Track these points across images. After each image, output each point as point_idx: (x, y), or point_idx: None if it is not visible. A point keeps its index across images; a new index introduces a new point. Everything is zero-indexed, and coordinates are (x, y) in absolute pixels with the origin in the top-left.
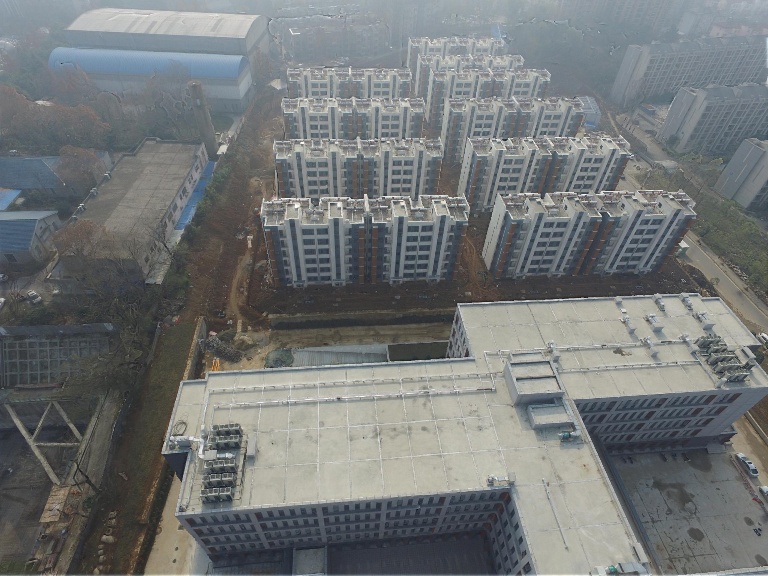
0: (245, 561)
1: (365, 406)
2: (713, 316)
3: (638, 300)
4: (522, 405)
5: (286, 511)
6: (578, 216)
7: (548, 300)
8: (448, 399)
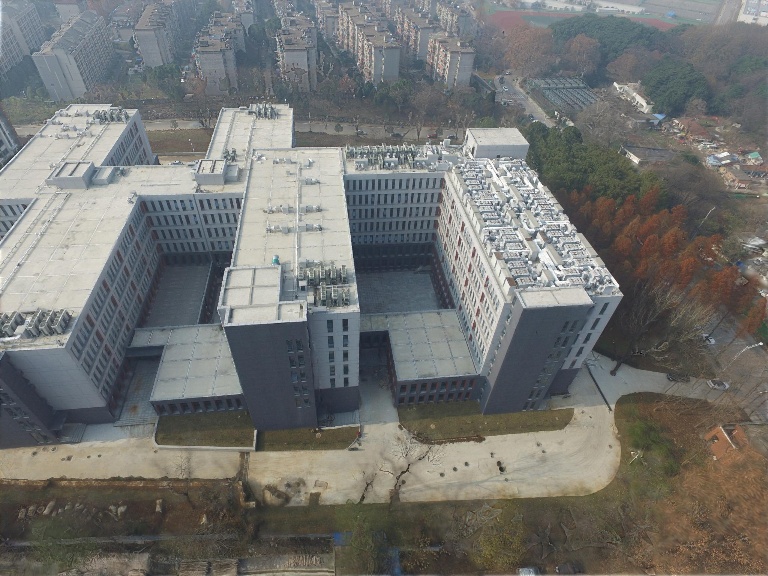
0: (123, 395)
1: (37, 252)
2: None
3: (46, 129)
4: (89, 185)
5: (97, 299)
6: None
7: (11, 160)
8: (61, 213)
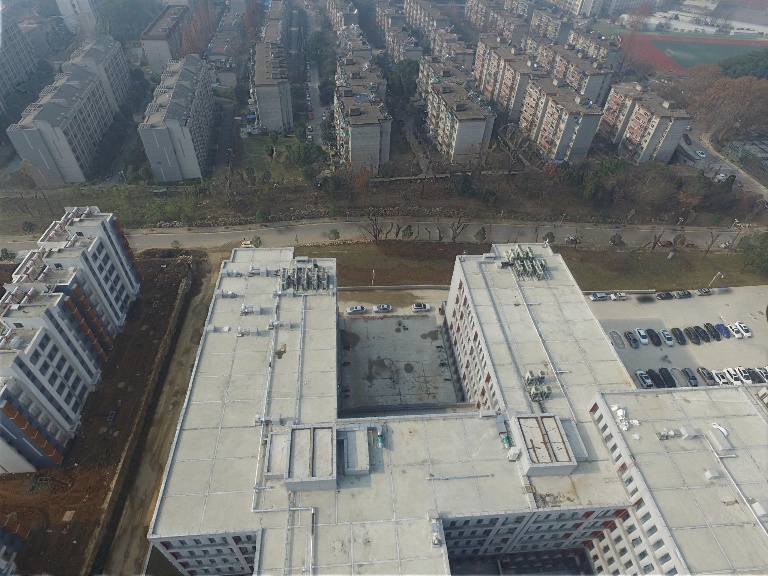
0: None
1: None
2: (254, 263)
3: (215, 311)
4: (338, 479)
5: None
6: (48, 317)
7: (186, 402)
8: None
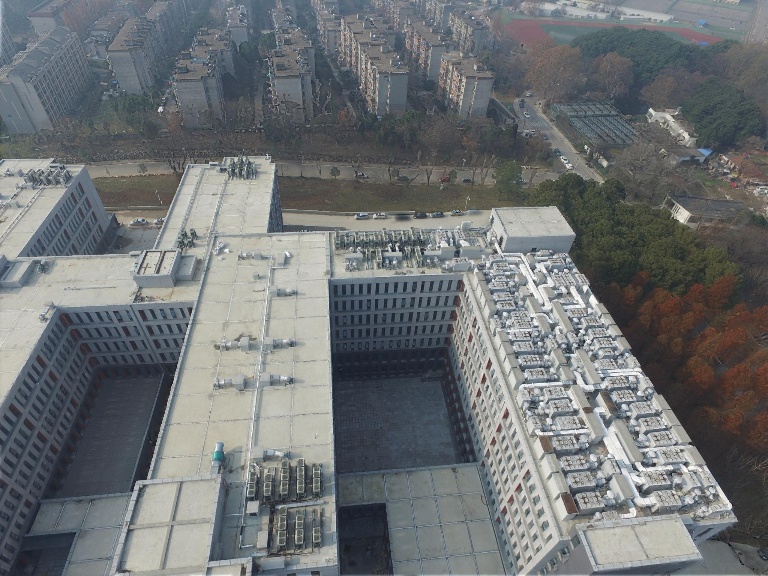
0: None
1: None
2: None
3: None
4: None
5: None
6: None
7: None
8: None
